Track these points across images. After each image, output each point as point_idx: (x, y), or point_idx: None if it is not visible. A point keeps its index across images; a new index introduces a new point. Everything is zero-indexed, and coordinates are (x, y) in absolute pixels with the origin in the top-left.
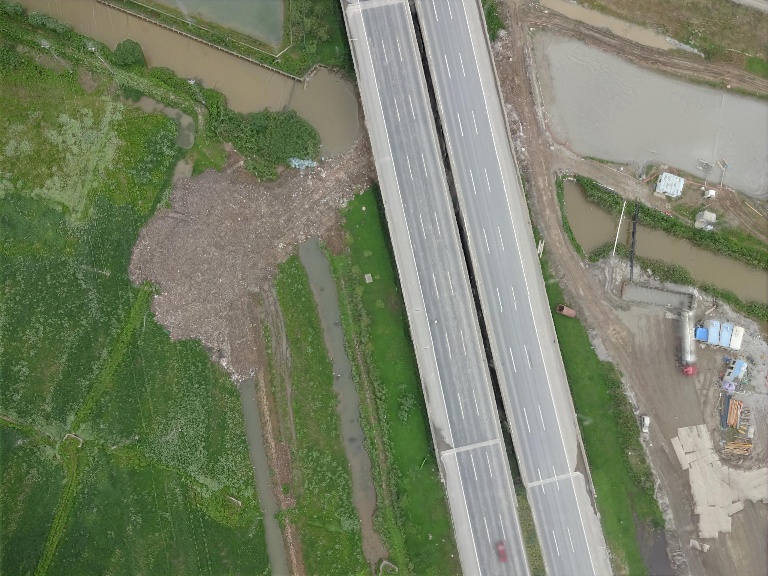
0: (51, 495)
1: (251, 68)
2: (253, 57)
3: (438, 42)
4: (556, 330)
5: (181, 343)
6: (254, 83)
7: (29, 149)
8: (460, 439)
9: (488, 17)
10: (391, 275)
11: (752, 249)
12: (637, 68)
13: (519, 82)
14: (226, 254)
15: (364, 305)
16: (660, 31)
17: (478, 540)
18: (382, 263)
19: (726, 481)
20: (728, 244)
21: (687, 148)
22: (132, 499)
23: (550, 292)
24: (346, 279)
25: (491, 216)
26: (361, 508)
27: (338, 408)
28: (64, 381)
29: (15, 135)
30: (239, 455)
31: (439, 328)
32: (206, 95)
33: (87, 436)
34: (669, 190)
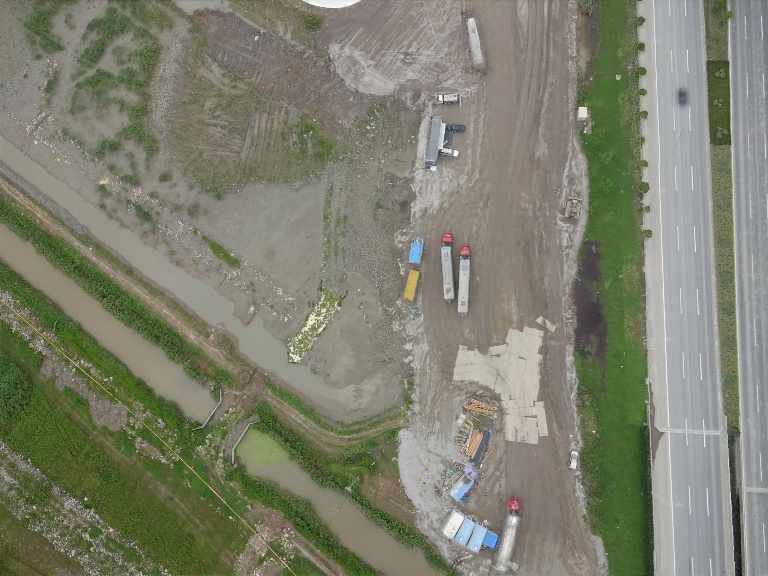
0: None
1: None
2: None
3: None
4: None
5: None
6: None
7: None
8: None
9: None
10: None
11: None
12: None
13: None
14: None
15: None
16: None
17: None
18: None
19: (500, 378)
20: None
21: None
22: None
23: None
24: None
25: None
26: None
27: None
28: None
29: None
30: None
31: None
32: None
33: None
34: None
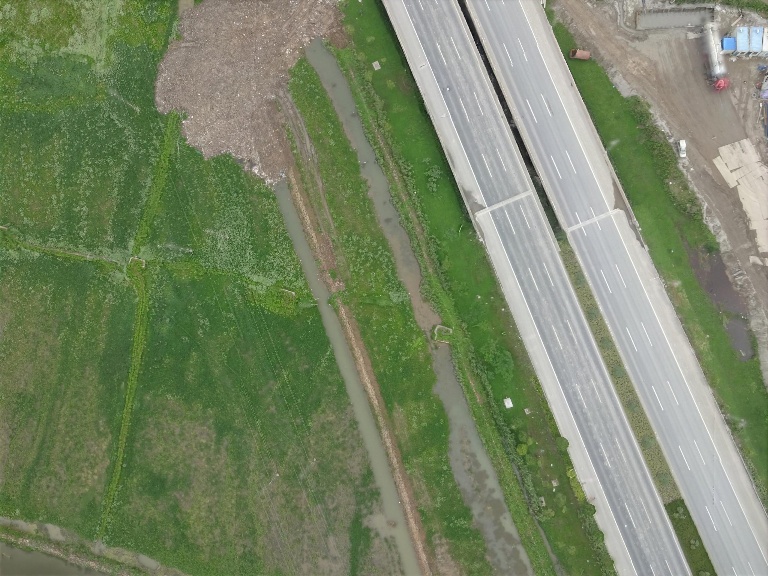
0: (128, 314)
1: None
2: None
3: None
4: (572, 75)
5: (214, 160)
6: None
7: (49, 14)
8: (491, 197)
9: None
10: (398, 58)
11: None
12: None
13: None
14: (239, 70)
15: (376, 92)
16: None
17: (526, 291)
18: (387, 48)
19: None
20: None
21: None
22: (198, 306)
23: (560, 40)
24: (354, 70)
25: None
26: (407, 282)
27: (369, 193)
28: (119, 213)
29: (35, 4)
30: (285, 251)
31: (452, 94)
32: None
33: (148, 257)
34: None
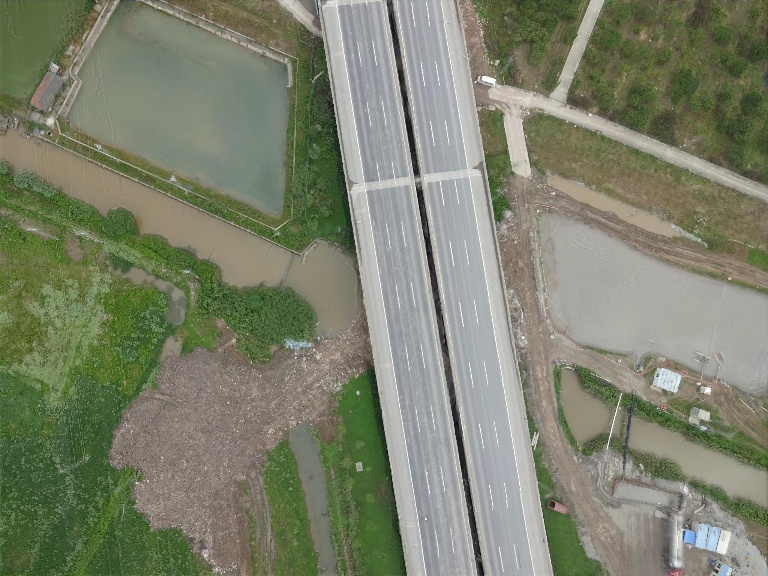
0: None
1: (248, 238)
2: (251, 229)
3: (443, 228)
4: (546, 527)
5: (161, 533)
6: (251, 255)
7: (8, 321)
8: None
9: (495, 197)
10: (382, 463)
11: (743, 447)
12: (641, 255)
13: (522, 265)
14: (213, 440)
15: (353, 495)
16: (666, 218)
17: None
18: (374, 451)
19: None
20: (720, 441)
21: (685, 339)
22: None
23: (542, 486)
24: (336, 469)
25: (487, 410)
26: None
27: None
28: (35, 572)
29: None
30: None
31: (429, 525)
32: (200, 269)
33: None
34: (666, 387)
